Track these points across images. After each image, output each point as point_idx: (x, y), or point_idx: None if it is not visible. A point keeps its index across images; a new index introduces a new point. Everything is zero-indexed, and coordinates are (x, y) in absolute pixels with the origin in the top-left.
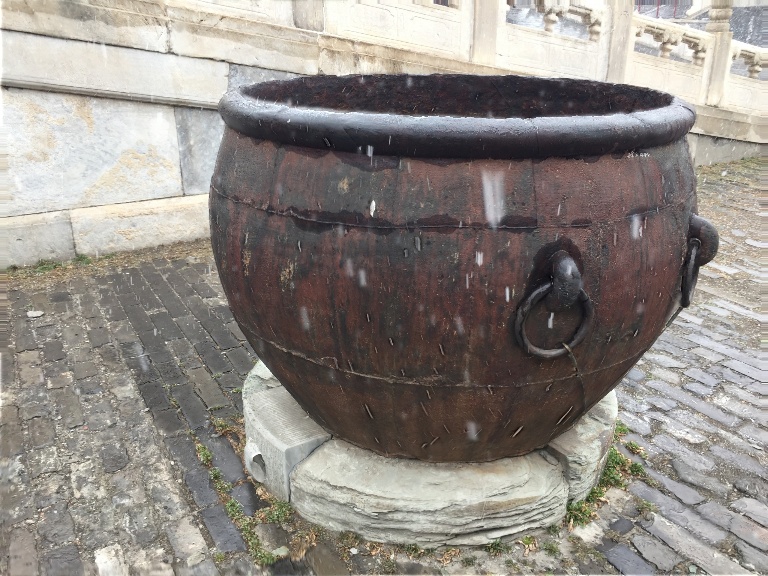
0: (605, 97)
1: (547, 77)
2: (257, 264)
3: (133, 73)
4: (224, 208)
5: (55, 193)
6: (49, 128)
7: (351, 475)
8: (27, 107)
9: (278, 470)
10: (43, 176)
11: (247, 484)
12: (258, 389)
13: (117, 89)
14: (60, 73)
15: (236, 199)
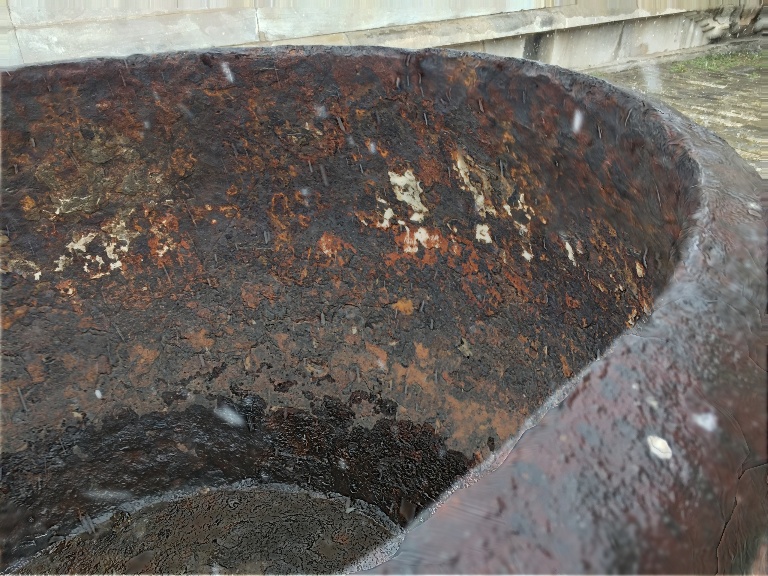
0: None
1: None
2: None
3: None
4: None
5: None
6: None
7: None
8: None
9: None
10: None
11: None
12: None
13: None
14: None
15: None
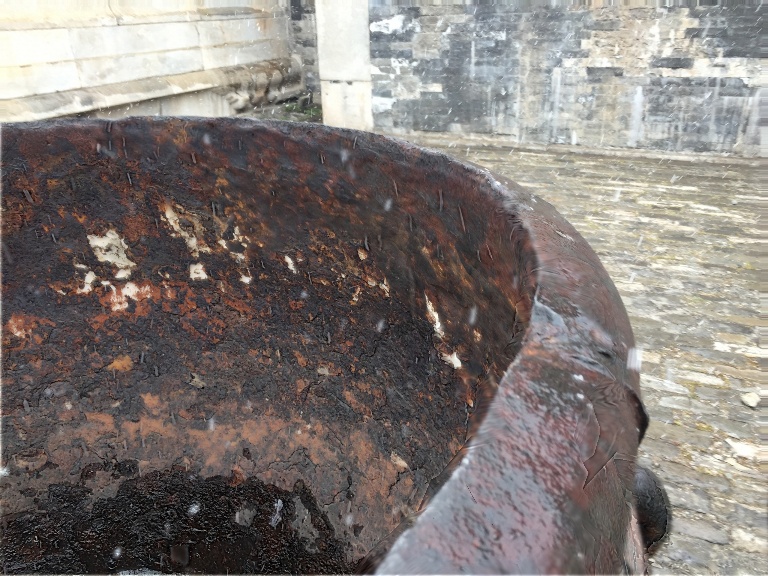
0: None
1: None
2: None
3: None
4: None
5: None
6: None
7: None
8: None
9: None
10: None
11: None
12: None
13: None
14: None
15: None
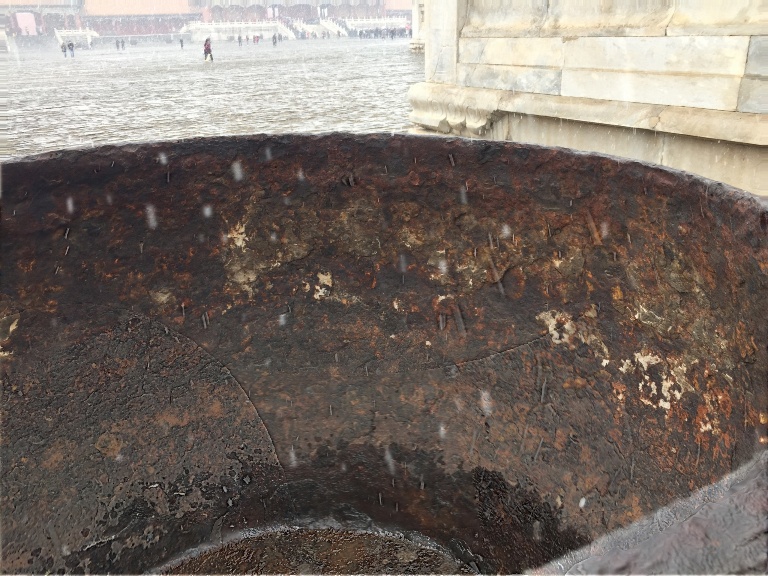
0: (159, 166)
1: (12, 157)
2: None
3: None
4: None
5: None
6: None
7: None
8: None
9: None
10: None
11: None
12: None
13: None
14: None
15: None
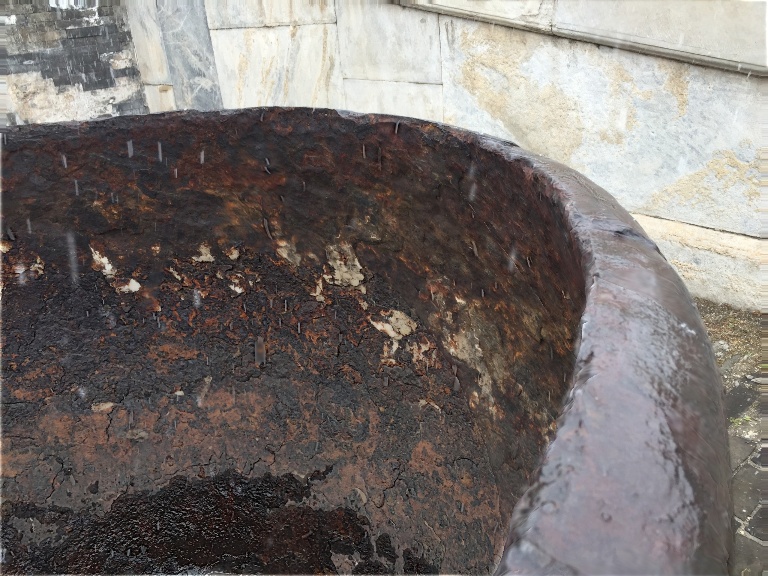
0: None
1: None
2: None
3: (755, 29)
4: None
5: (620, 187)
6: (631, 102)
7: None
8: (614, 72)
9: None
10: (612, 162)
11: None
12: None
13: (723, 55)
14: (653, 28)
15: None
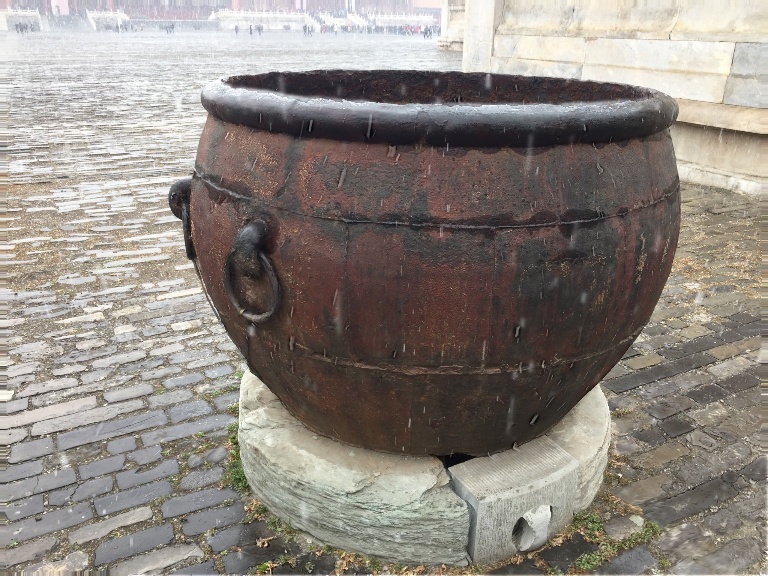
0: (361, 84)
1: None
2: (650, 260)
3: None
4: (609, 230)
5: None
6: None
7: (594, 430)
8: None
9: (571, 493)
10: None
11: (545, 555)
12: (449, 495)
13: None
14: None
15: (624, 211)
